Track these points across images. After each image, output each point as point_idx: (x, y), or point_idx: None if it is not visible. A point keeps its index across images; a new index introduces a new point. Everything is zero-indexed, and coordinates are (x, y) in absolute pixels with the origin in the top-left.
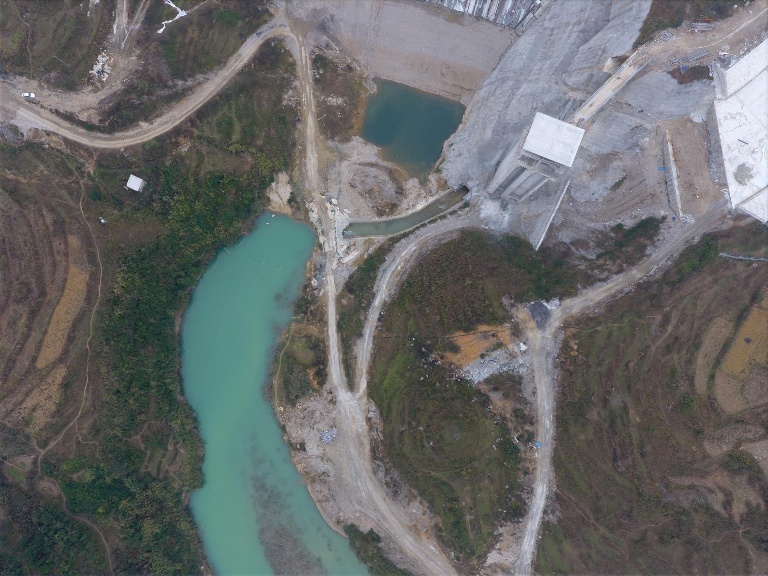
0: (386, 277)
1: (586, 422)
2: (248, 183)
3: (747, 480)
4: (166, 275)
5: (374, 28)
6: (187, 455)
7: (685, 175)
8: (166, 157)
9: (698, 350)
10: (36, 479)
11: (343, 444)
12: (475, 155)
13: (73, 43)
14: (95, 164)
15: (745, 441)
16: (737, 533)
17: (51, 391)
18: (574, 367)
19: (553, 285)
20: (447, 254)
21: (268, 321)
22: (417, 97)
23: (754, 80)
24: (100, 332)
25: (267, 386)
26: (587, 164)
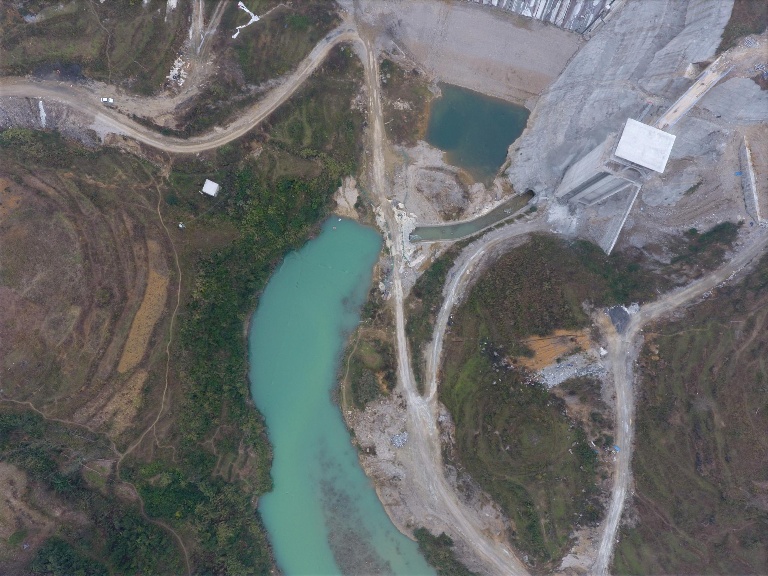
0: (455, 281)
1: (668, 426)
2: (317, 187)
3: None
4: (238, 279)
5: (441, 33)
6: (258, 459)
7: (763, 180)
8: (239, 162)
9: None
10: (115, 483)
11: (414, 448)
12: (544, 160)
13: (151, 48)
14: (170, 169)
15: None
16: None
17: (132, 396)
18: (656, 372)
19: (631, 290)
20: (521, 259)
21: (335, 325)
22: (481, 101)
23: None
24: (180, 337)
25: (335, 390)
26: None
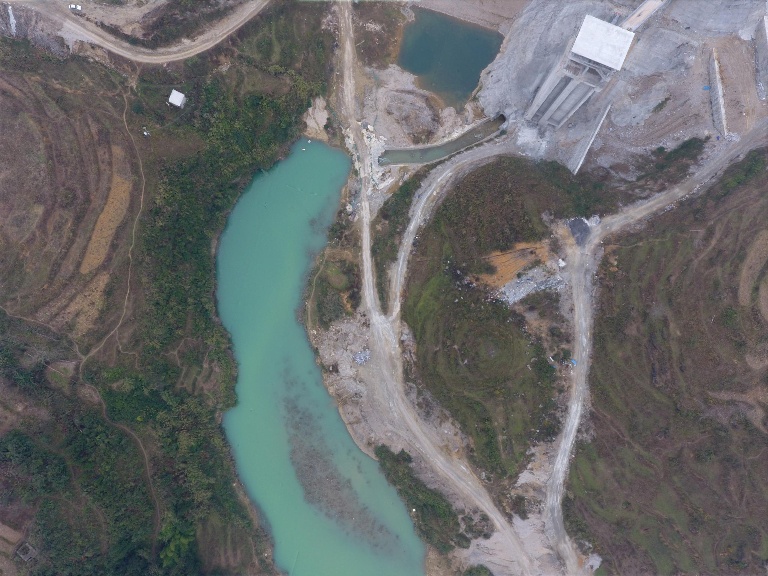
0: (421, 202)
1: (624, 338)
2: (286, 106)
3: None
4: (205, 193)
5: None
6: (222, 373)
7: (731, 93)
8: (207, 75)
9: (743, 262)
10: (78, 385)
11: (376, 366)
12: (514, 80)
13: None
14: (138, 79)
15: None
16: None
17: (94, 297)
18: (614, 282)
19: (593, 203)
20: (485, 175)
21: (302, 246)
22: (455, 26)
23: None
24: (142, 241)
25: (301, 309)
26: (629, 87)
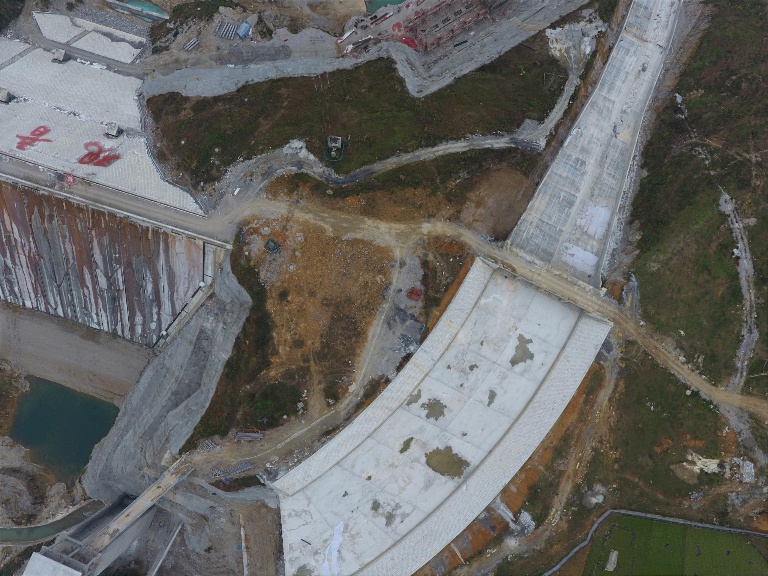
0: None
1: None
2: None
3: None
4: None
5: (15, 336)
6: None
7: (253, 565)
8: None
9: None
10: None
11: None
12: (99, 482)
13: None
14: None
15: None
16: None
17: None
18: None
19: None
20: None
21: None
22: (72, 395)
23: (324, 475)
24: None
25: None
26: (188, 518)
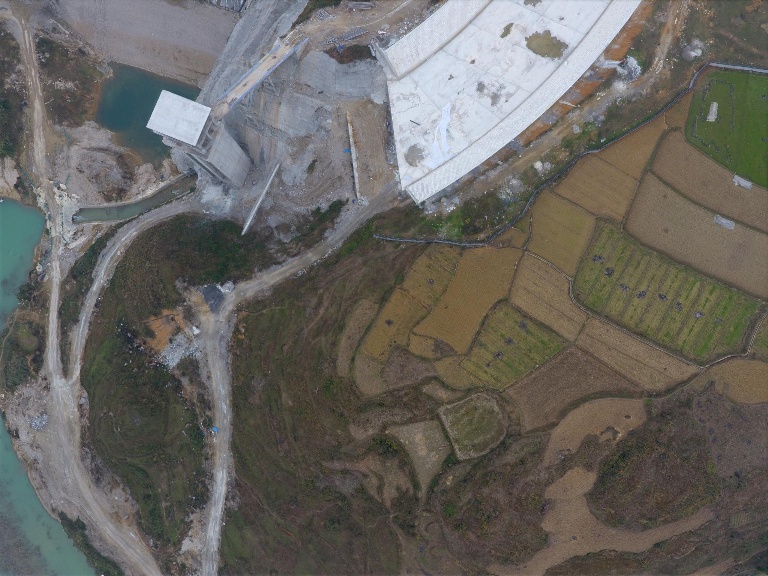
0: (105, 262)
1: (251, 406)
2: None
3: (398, 464)
4: None
5: (100, 11)
6: None
7: (363, 157)
8: None
9: (341, 332)
10: None
11: (53, 431)
12: None
13: None
14: None
15: (391, 424)
16: (388, 518)
17: None
18: (239, 350)
19: (232, 268)
20: (144, 238)
21: None
22: (156, 82)
23: (429, 60)
24: None
25: None
26: (288, 147)
